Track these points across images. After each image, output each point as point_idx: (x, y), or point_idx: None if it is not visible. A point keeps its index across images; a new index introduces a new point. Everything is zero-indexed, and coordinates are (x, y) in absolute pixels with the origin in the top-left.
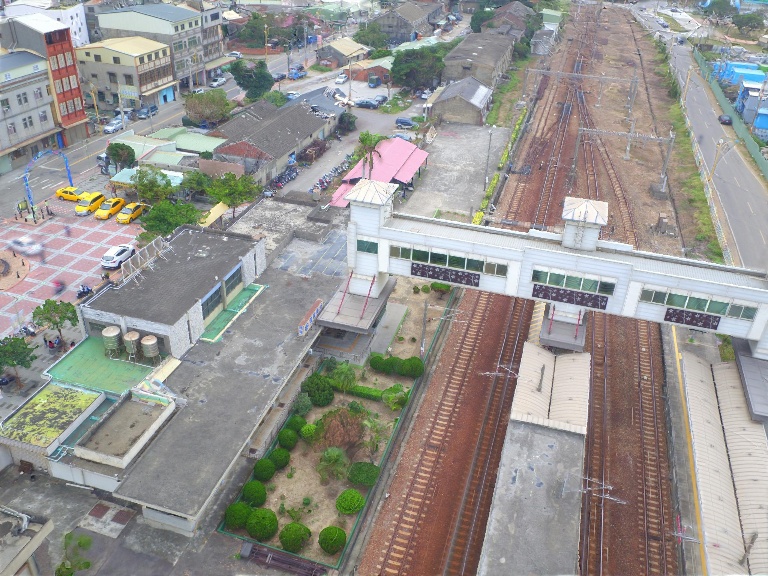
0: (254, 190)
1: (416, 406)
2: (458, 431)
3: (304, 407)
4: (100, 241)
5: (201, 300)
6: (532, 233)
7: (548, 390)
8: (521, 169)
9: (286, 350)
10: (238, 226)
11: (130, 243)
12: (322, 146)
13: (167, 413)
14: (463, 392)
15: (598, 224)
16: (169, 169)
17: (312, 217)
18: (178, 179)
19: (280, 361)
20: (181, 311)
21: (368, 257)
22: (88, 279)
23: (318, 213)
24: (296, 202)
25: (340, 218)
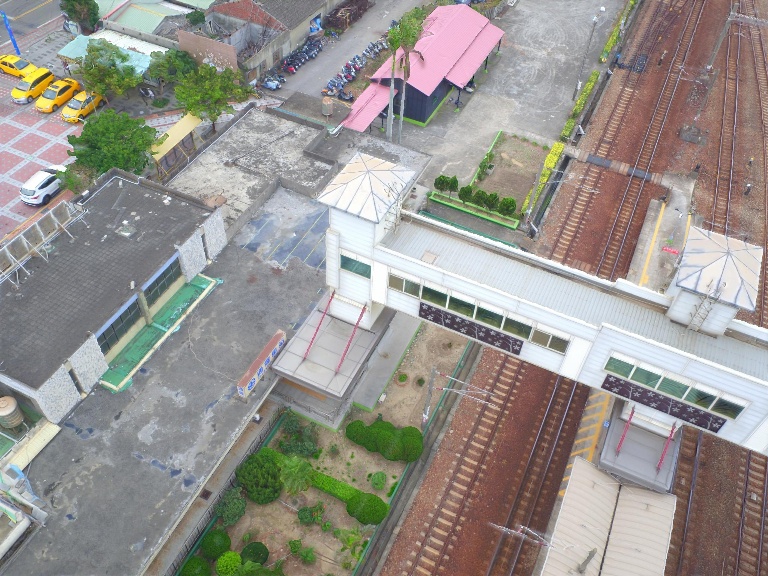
0: (239, 95)
1: (401, 511)
2: (452, 574)
3: (231, 515)
4: (33, 152)
5: (98, 331)
6: (621, 285)
7: (596, 564)
8: (632, 61)
9: (217, 419)
10: (205, 159)
11: (70, 159)
12: (362, 3)
13: (13, 538)
14: (474, 492)
15: (738, 306)
16: (141, 38)
17: (310, 153)
18: (146, 60)
19: (203, 442)
20: (63, 352)
21: (357, 279)
22: (0, 220)
23: (324, 140)
24: (295, 119)
25: (353, 152)
